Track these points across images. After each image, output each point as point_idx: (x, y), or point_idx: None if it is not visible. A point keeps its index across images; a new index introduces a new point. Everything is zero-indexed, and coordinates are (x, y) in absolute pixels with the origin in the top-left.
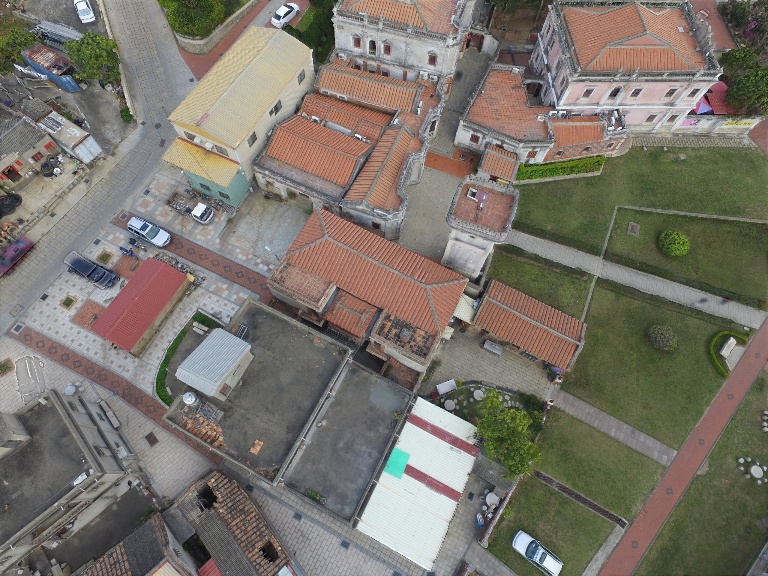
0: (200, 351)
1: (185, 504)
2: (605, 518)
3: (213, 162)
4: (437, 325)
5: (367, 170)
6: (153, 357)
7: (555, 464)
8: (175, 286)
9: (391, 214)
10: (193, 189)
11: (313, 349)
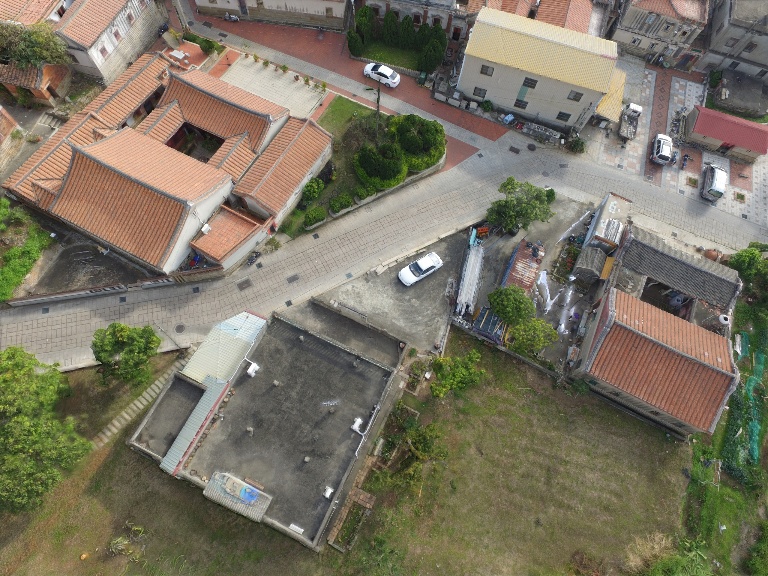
0: None
1: None
2: None
3: None
4: None
5: None
6: None
7: None
8: None
9: None
10: None
11: None
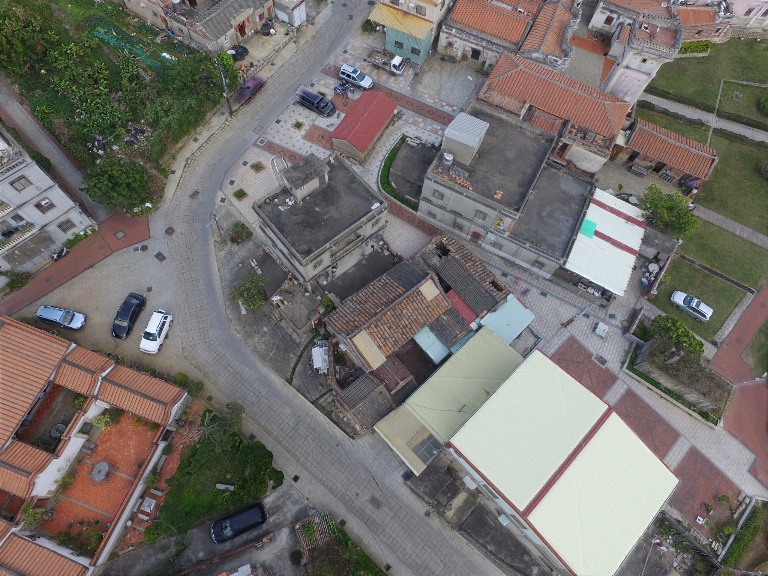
0: (457, 122)
1: (427, 253)
2: (738, 287)
3: (411, 21)
4: (614, 130)
5: (535, 31)
6: (373, 166)
7: (695, 251)
8: (390, 111)
9: (562, 59)
10: (385, 49)
11: (526, 138)
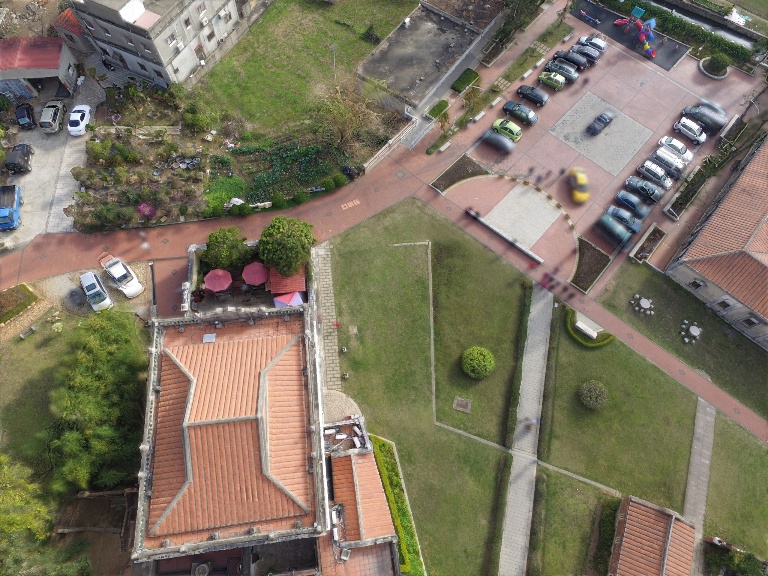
0: None
1: None
2: None
3: None
4: None
5: None
6: None
7: (759, 529)
8: None
9: None
10: None
11: None
